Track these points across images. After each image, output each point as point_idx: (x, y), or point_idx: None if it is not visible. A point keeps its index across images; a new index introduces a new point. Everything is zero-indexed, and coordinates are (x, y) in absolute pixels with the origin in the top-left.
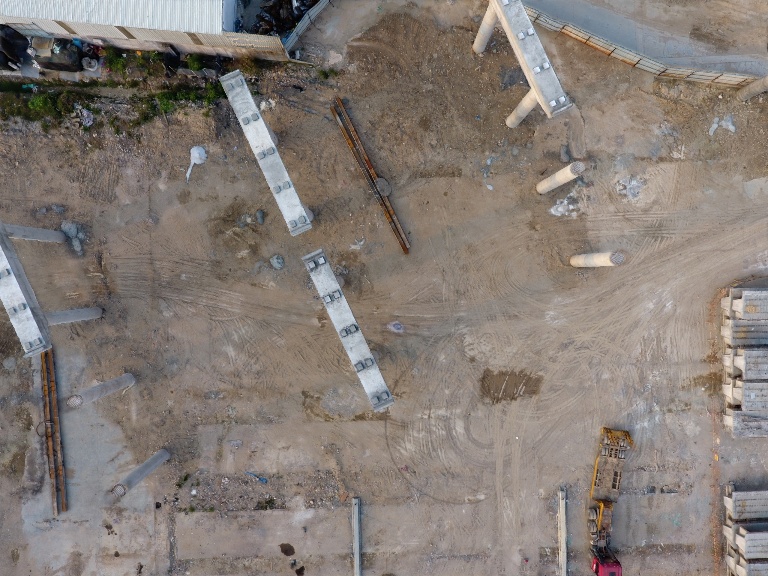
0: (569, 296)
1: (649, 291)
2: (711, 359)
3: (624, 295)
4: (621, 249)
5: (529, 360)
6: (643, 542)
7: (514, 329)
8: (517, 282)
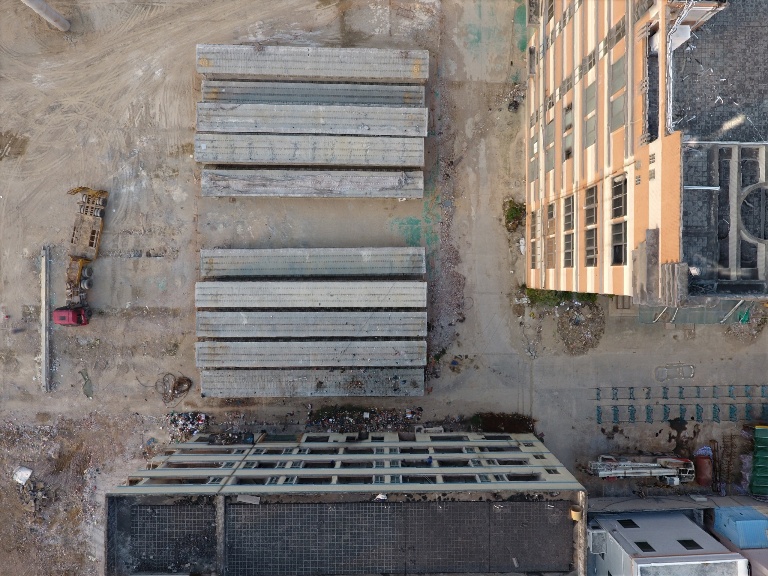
0: (57, 60)
1: (138, 58)
2: None
3: (113, 61)
4: (111, 16)
5: (15, 121)
6: (127, 304)
7: (1, 90)
8: (4, 44)
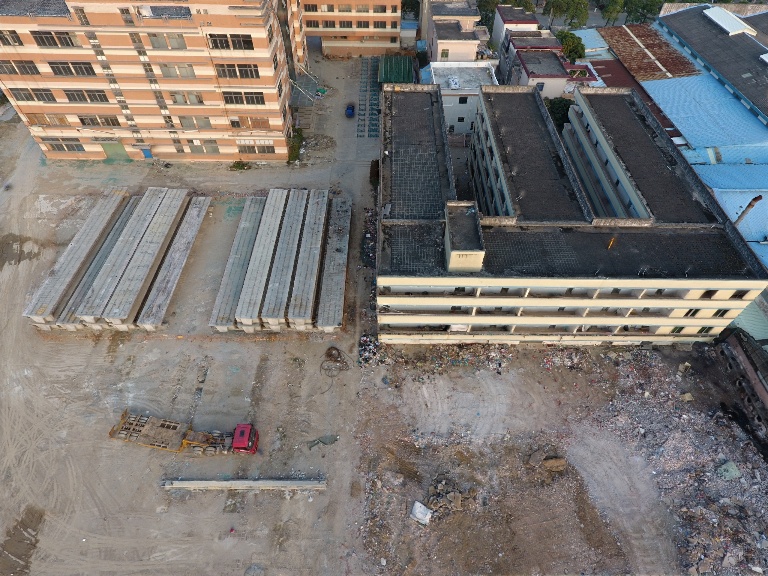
0: None
1: (2, 390)
2: (94, 339)
3: None
4: None
5: None
6: (246, 400)
7: None
8: None
